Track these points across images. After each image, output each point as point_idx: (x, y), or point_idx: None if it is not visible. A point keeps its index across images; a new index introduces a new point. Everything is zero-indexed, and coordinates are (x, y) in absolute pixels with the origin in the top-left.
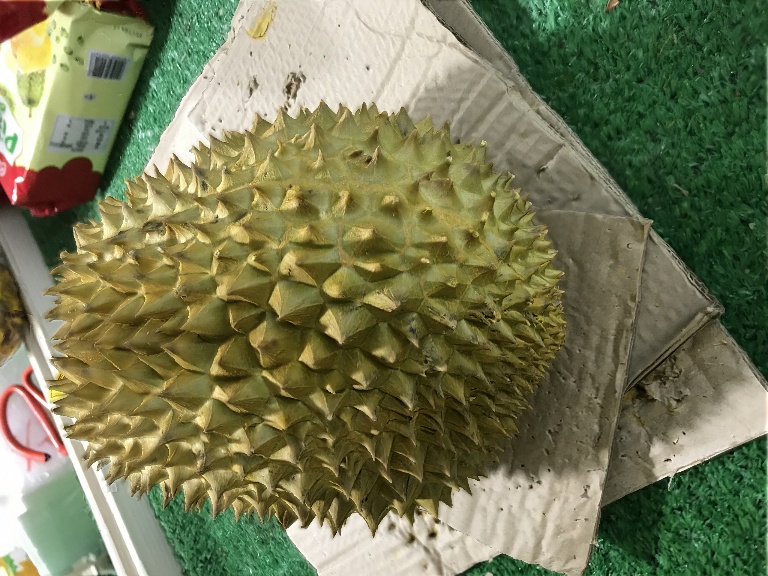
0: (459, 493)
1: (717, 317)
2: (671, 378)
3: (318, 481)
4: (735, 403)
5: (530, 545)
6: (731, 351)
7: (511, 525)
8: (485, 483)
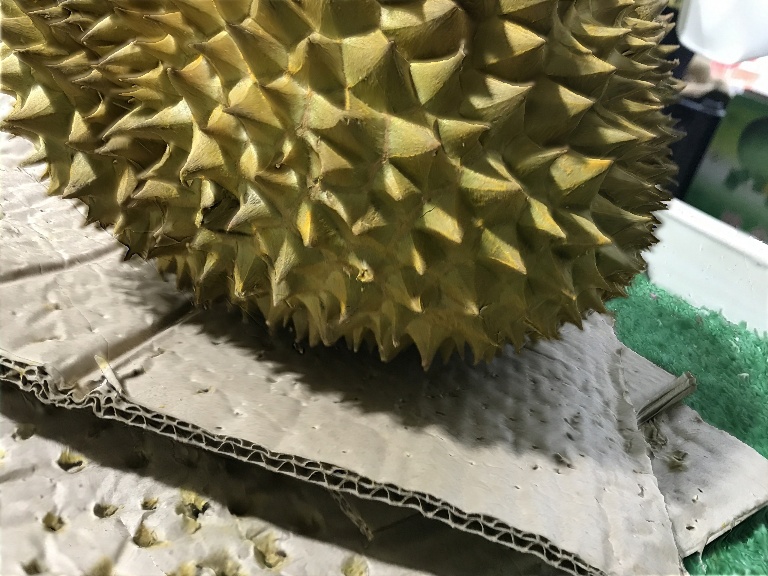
0: (424, 454)
1: (695, 387)
2: (660, 443)
3: (574, 7)
4: (739, 462)
5: (595, 536)
6: (709, 426)
7: (546, 506)
8: (471, 456)
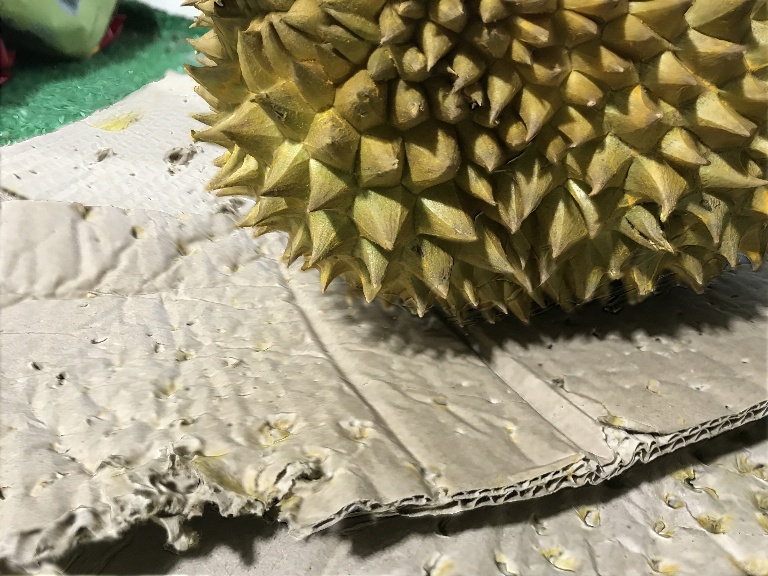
0: None
1: None
2: None
3: None
4: None
5: None
6: None
7: None
8: None
